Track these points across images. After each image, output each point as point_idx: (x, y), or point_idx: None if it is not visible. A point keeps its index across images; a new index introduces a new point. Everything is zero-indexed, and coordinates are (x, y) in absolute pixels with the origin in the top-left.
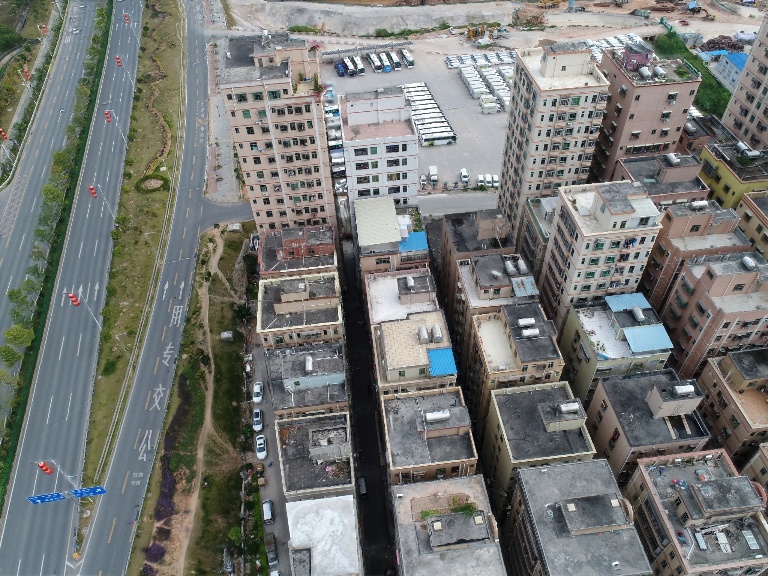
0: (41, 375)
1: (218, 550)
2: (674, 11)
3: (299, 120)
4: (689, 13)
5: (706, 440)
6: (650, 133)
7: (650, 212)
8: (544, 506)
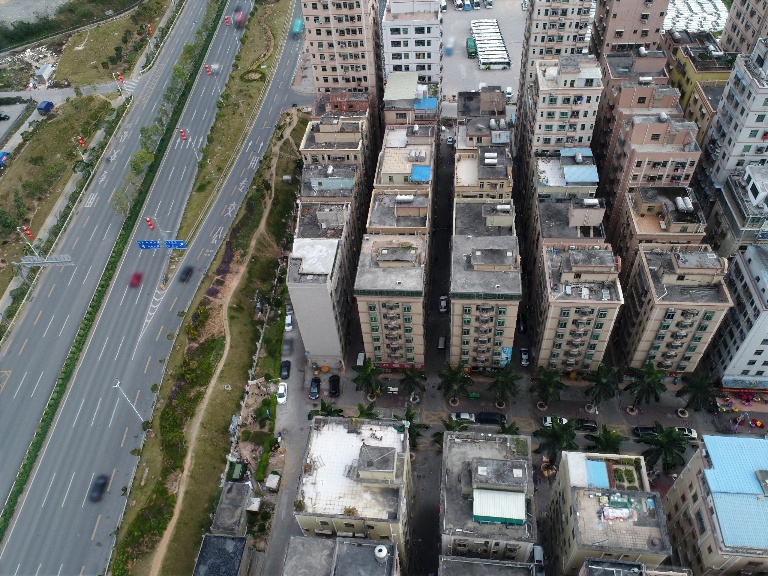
0: (155, 188)
1: None
2: None
3: (350, 0)
4: None
5: (603, 242)
6: (632, 33)
7: (594, 75)
8: (462, 255)
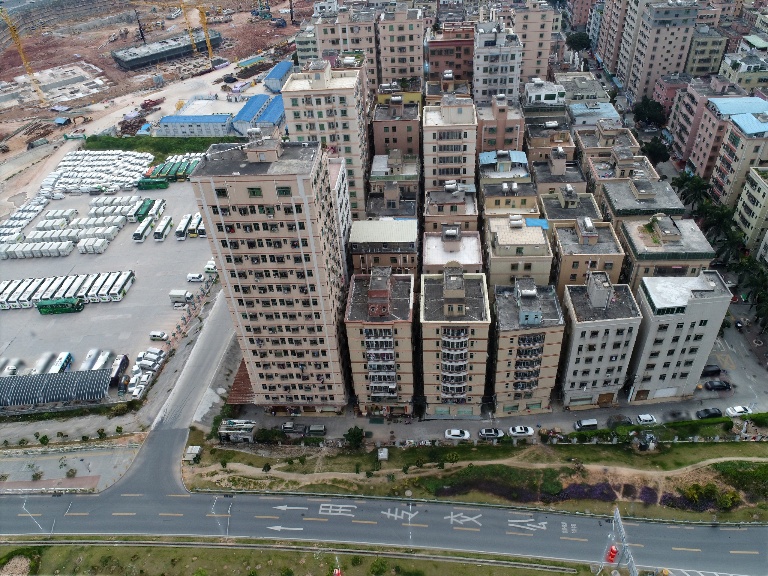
0: None
1: (630, 456)
2: (53, 131)
3: (327, 183)
4: (65, 127)
5: None
6: (367, 98)
7: None
8: (639, 204)
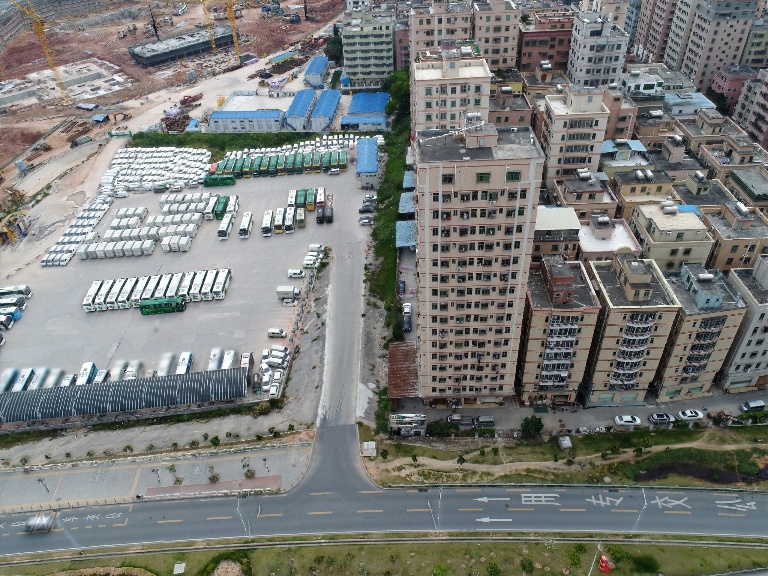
0: None
1: None
2: (93, 129)
3: None
4: (104, 124)
5: None
6: None
7: None
8: None
